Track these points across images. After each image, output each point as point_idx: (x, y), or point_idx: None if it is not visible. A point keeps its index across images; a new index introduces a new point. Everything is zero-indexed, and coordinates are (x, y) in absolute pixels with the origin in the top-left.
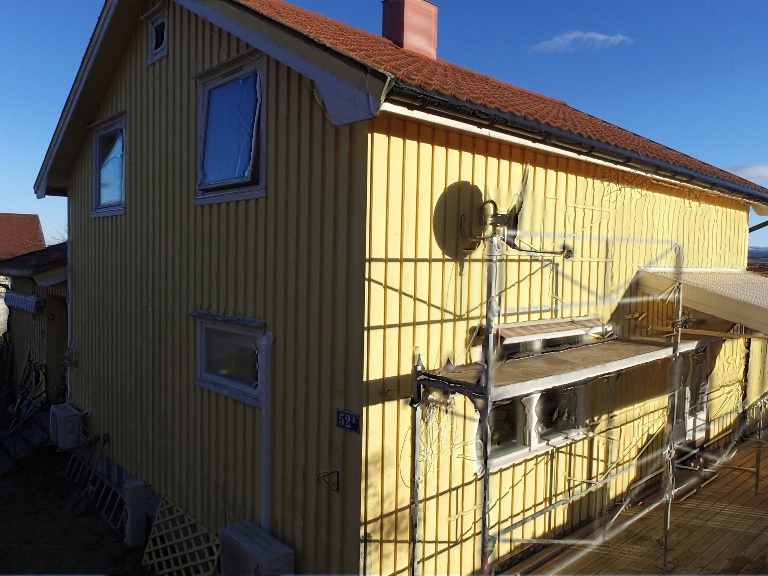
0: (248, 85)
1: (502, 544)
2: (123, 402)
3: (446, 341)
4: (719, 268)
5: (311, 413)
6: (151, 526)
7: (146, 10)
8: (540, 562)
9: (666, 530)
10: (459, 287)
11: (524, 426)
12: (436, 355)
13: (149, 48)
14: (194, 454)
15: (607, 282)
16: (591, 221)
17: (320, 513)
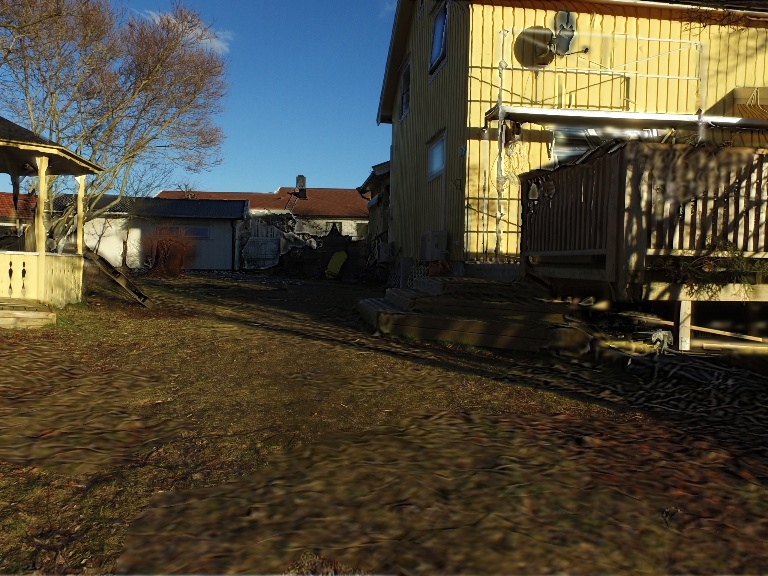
0: (445, 7)
1: None
2: (406, 221)
3: None
4: None
5: None
6: None
7: None
8: None
9: None
10: (535, 85)
11: None
12: None
13: None
14: None
15: (690, 94)
16: (669, 50)
17: None
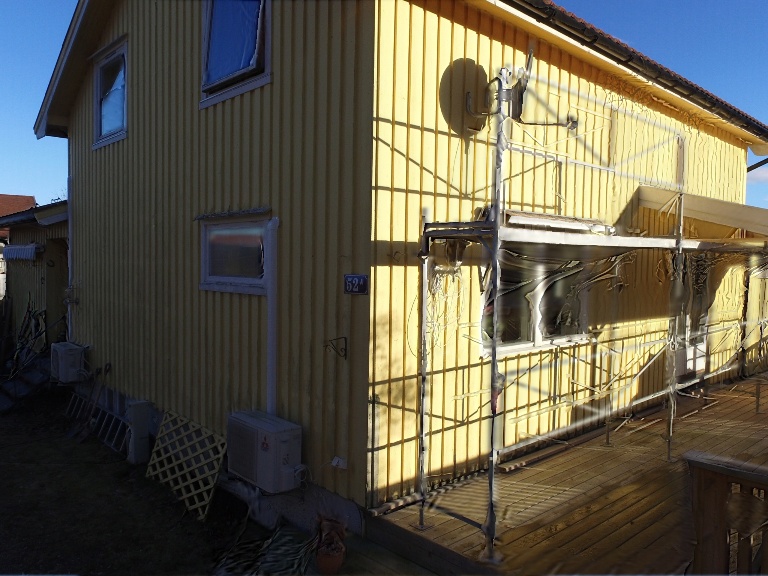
0: None
1: (507, 434)
2: (125, 327)
3: (452, 216)
4: None
5: (318, 287)
6: (155, 440)
7: None
8: (545, 456)
9: (669, 436)
10: (465, 165)
11: (528, 321)
12: None
13: None
14: (198, 360)
15: (609, 191)
16: (593, 127)
17: (327, 384)
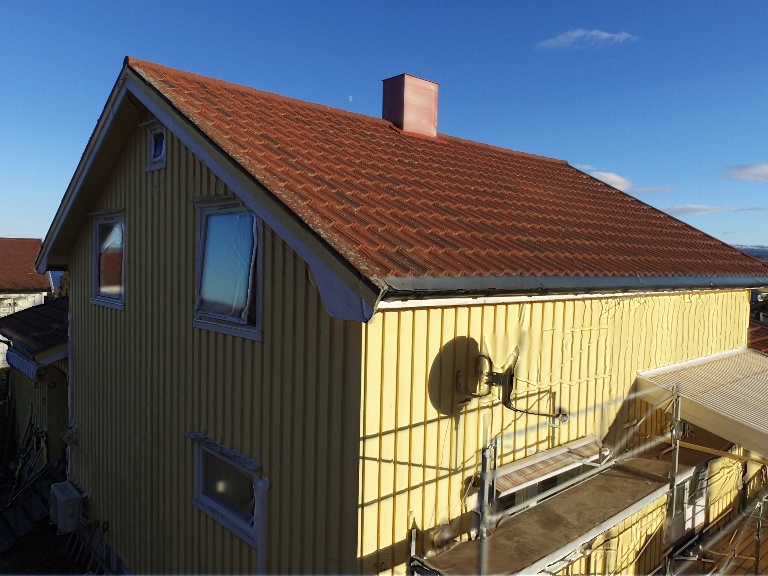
0: (245, 223)
1: None
2: (122, 496)
3: (441, 498)
4: (719, 352)
5: (306, 571)
6: None
7: (145, 120)
8: None
9: None
10: (454, 442)
11: None
12: (431, 514)
13: (148, 154)
14: (191, 572)
15: (605, 397)
16: (589, 341)
17: None
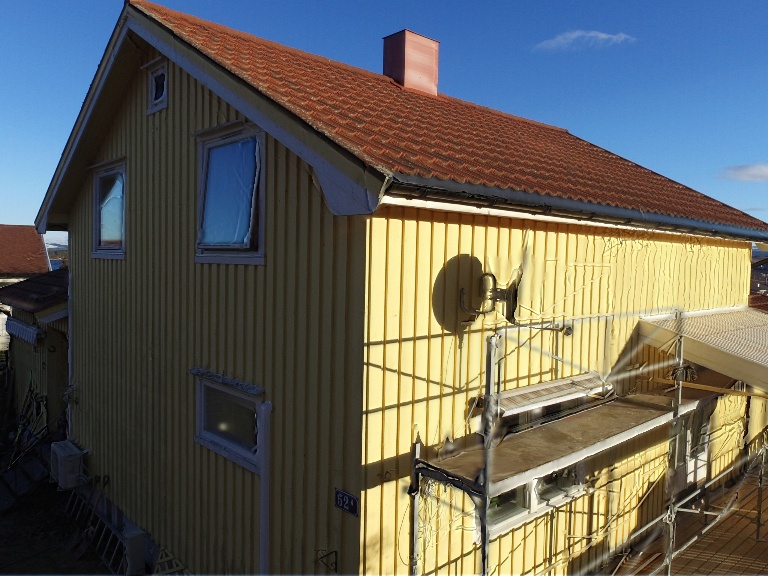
0: (247, 150)
1: None
2: (123, 447)
3: (445, 415)
4: (721, 308)
5: (310, 488)
6: None
7: (146, 61)
8: None
9: None
10: (458, 360)
11: (524, 488)
12: (435, 431)
13: (149, 97)
14: (193, 510)
15: (608, 336)
16: (592, 277)
17: None
